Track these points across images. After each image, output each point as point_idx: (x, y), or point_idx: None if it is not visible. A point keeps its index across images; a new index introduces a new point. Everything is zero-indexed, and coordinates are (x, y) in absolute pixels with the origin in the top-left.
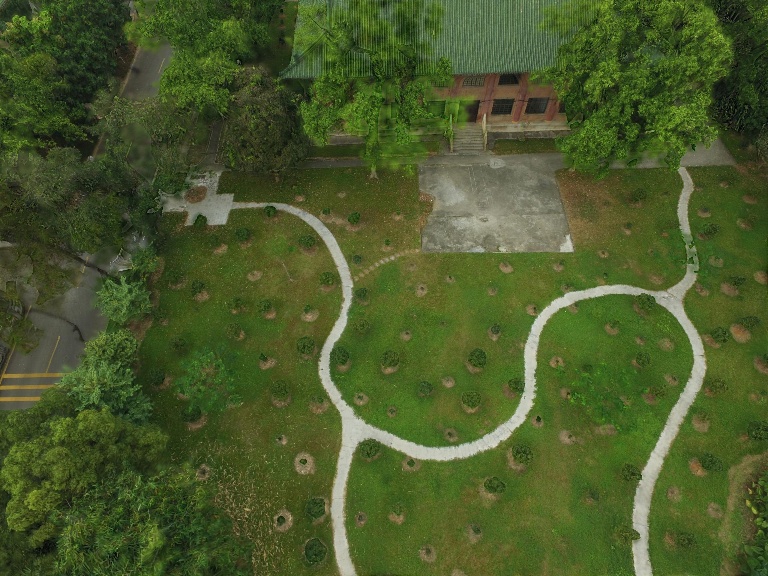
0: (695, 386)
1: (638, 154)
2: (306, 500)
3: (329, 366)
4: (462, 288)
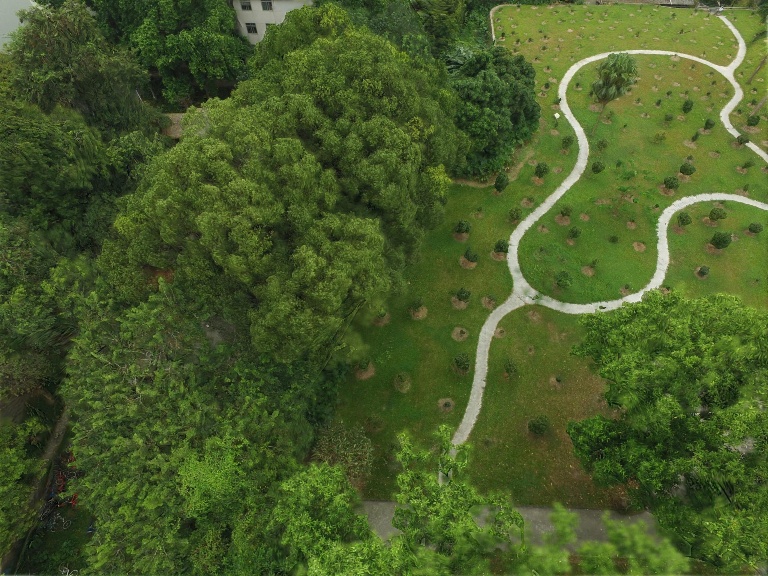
0: (524, 224)
1: (505, 543)
2: None
3: None
4: None
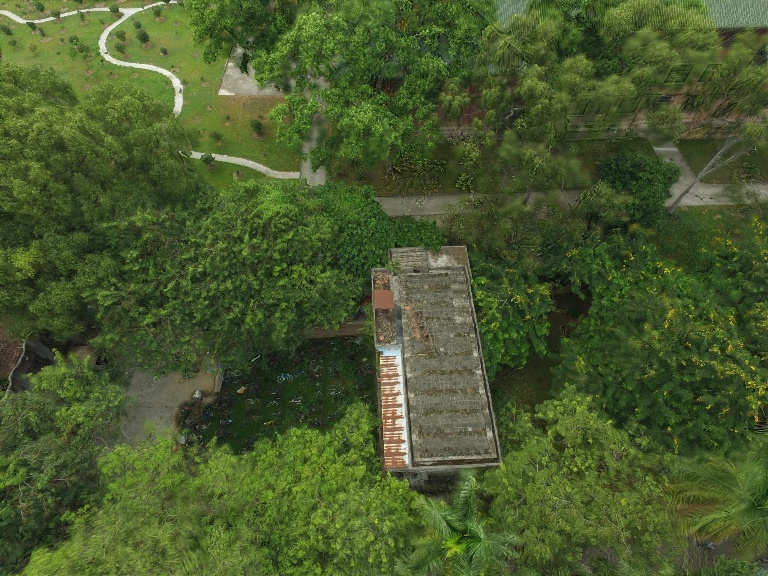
0: None
1: None
2: (105, 1)
3: (169, 3)
4: (202, 44)
